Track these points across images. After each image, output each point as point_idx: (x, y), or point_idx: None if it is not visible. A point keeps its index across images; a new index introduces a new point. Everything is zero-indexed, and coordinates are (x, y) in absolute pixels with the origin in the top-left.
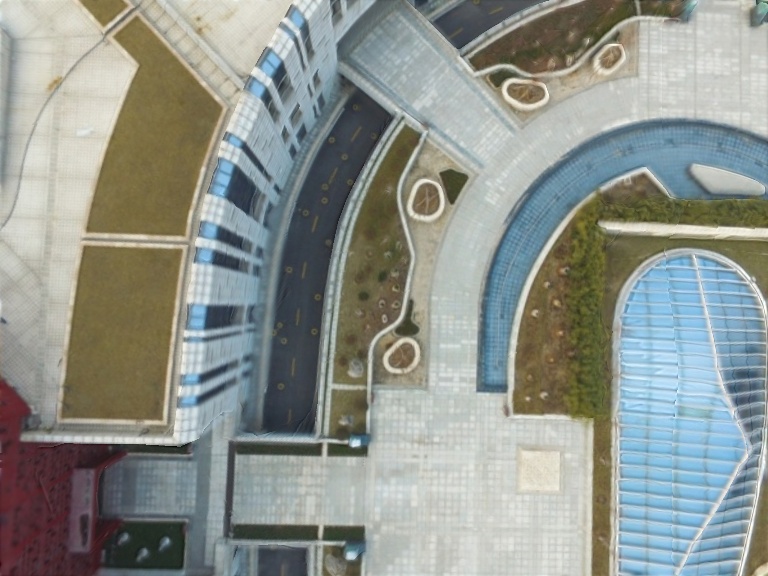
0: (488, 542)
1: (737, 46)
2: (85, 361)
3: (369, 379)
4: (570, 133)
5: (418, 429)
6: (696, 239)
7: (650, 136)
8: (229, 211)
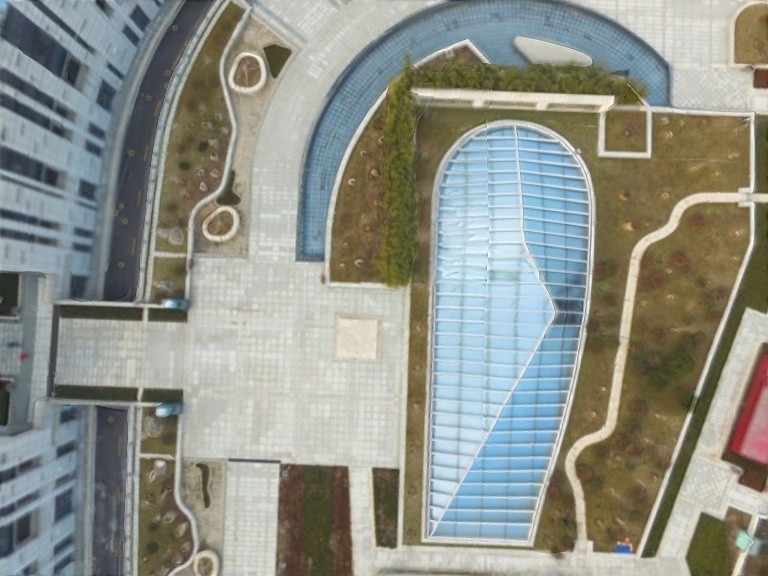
0: (304, 408)
1: None
2: None
3: (189, 247)
4: (395, 8)
5: (237, 296)
6: (517, 110)
7: (476, 10)
8: (10, 53)
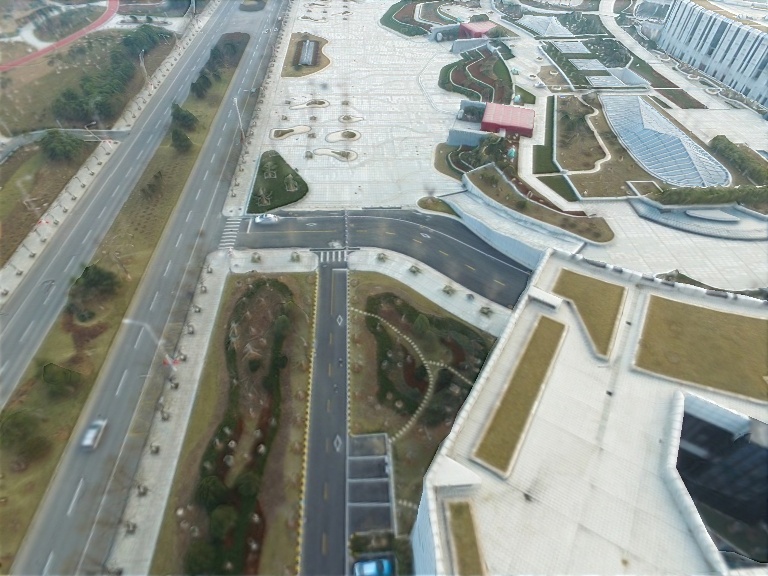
0: None
1: (762, 279)
2: None
3: None
4: None
5: None
6: None
7: None
8: None
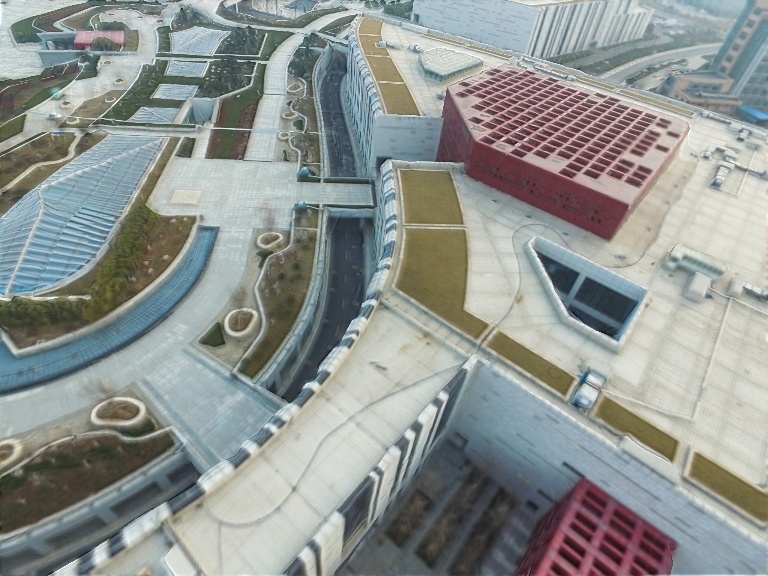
0: (226, 175)
1: None
2: (445, 187)
3: (293, 231)
4: (82, 382)
5: (262, 213)
6: None
7: None
8: None
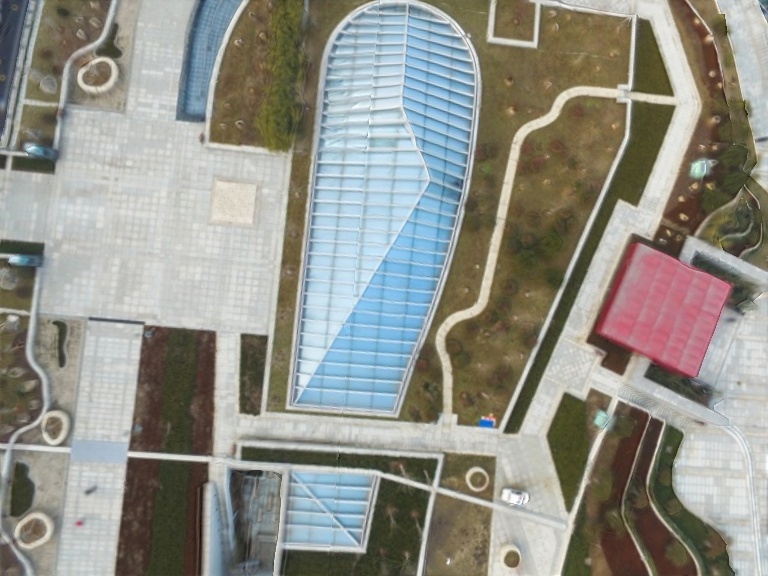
0: (174, 269)
1: None
2: None
3: (62, 96)
4: None
5: (111, 151)
6: None
7: None
8: None
